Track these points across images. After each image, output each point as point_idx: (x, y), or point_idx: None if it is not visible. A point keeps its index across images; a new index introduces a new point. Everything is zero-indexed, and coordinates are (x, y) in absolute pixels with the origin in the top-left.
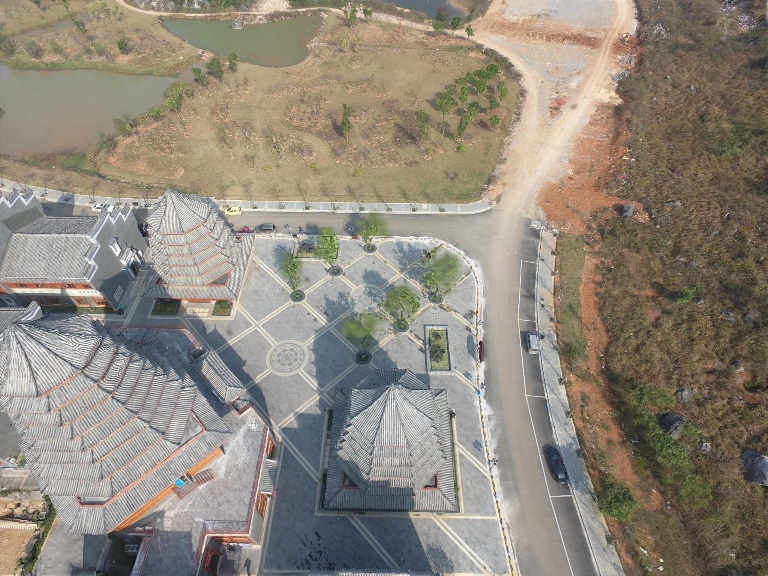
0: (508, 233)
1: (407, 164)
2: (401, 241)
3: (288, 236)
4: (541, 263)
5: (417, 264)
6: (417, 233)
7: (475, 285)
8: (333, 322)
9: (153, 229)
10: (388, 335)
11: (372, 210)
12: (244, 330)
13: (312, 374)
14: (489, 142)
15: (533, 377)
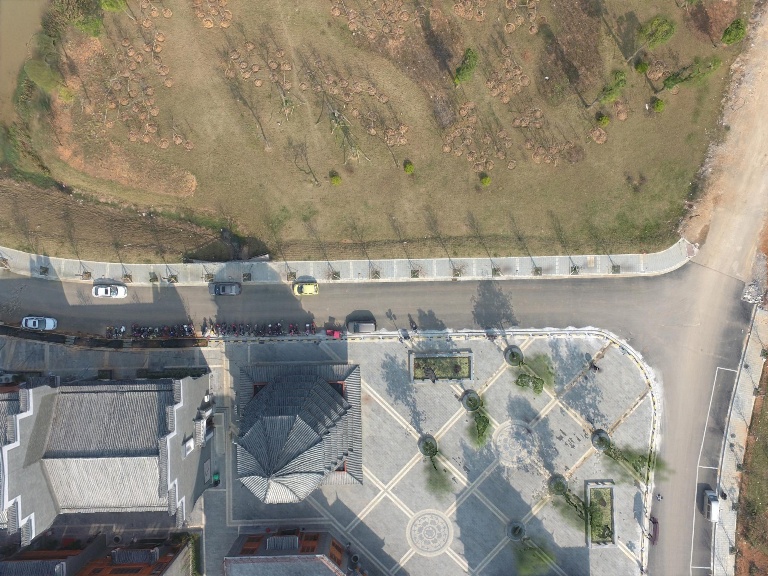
0: (707, 315)
1: (564, 156)
2: (556, 339)
3: (396, 336)
4: (743, 373)
5: (577, 381)
6: (578, 320)
7: (651, 415)
8: (476, 482)
9: (255, 494)
10: (542, 497)
11: (512, 274)
12: (372, 498)
13: (461, 553)
14: (706, 77)
15: (702, 545)
